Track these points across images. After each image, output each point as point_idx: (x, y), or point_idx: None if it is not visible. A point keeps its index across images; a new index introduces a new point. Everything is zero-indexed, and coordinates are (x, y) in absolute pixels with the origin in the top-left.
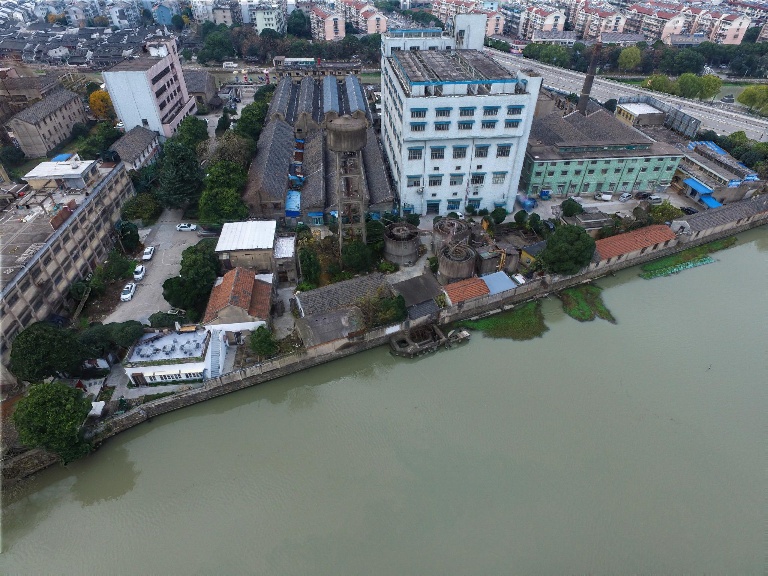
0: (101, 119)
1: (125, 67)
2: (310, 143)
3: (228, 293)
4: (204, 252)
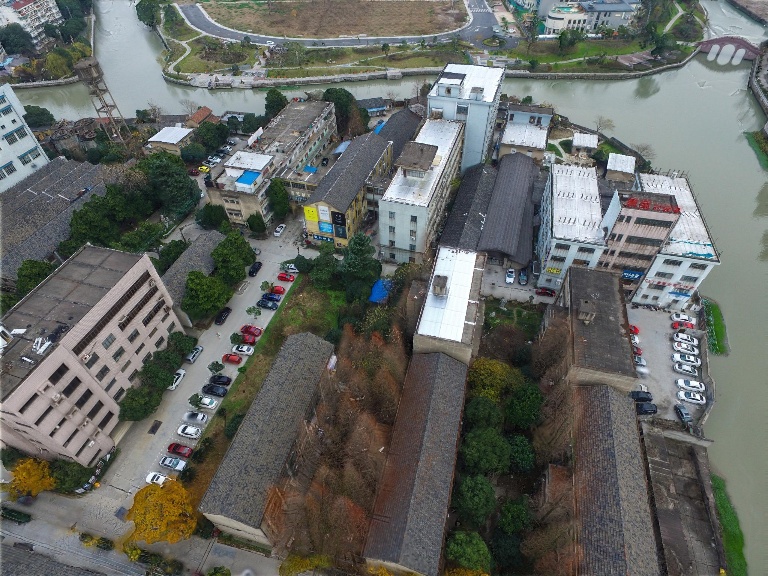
0: (191, 568)
1: (101, 274)
2: (0, 257)
3: (202, 111)
4: (199, 131)
